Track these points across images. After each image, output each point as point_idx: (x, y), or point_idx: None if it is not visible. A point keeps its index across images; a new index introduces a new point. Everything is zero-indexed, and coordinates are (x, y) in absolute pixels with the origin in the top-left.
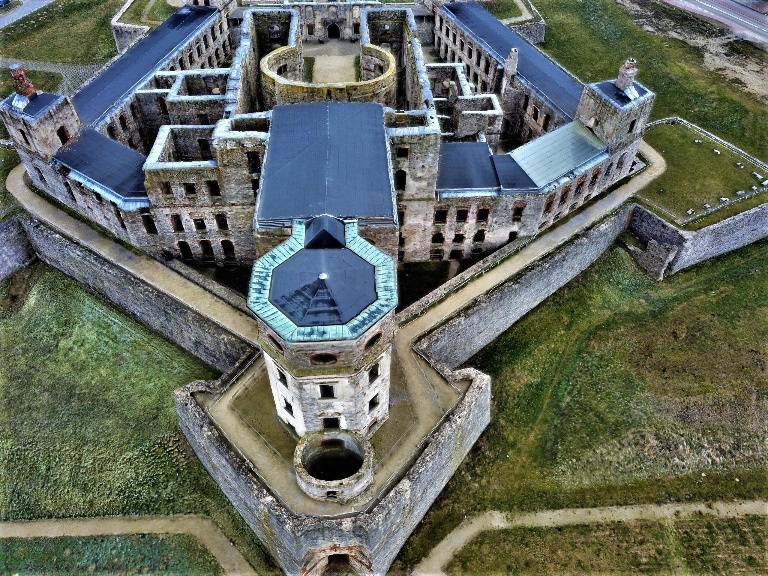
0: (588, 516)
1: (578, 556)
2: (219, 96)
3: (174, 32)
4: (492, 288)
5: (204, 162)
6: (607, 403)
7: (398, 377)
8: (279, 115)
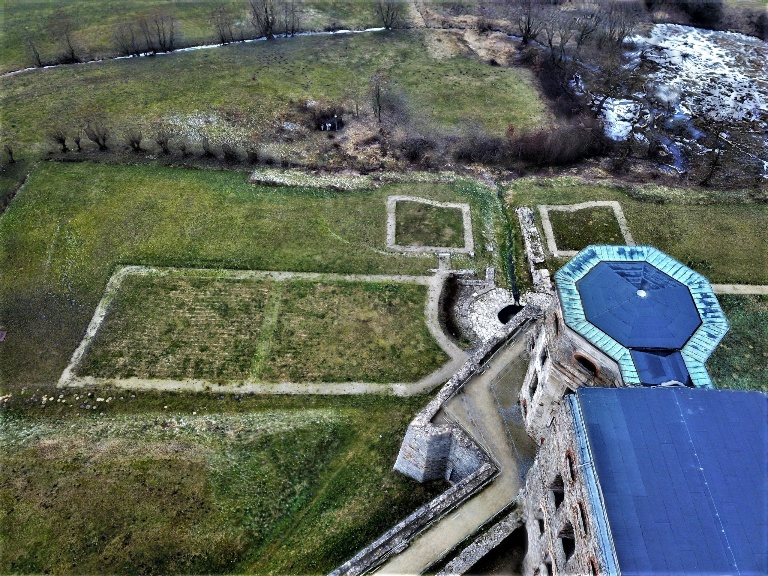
0: (320, 388)
1: (341, 360)
2: None
3: None
4: (380, 568)
5: None
6: (260, 469)
7: (513, 432)
8: None
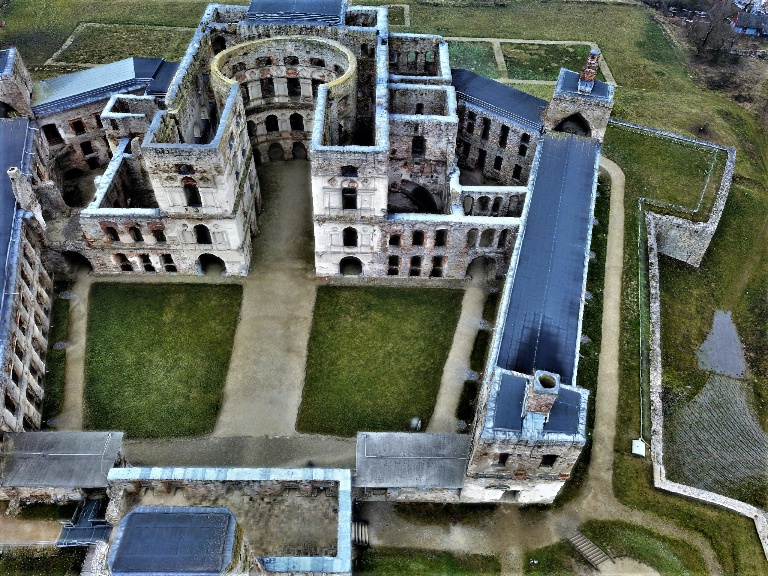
0: None
1: None
2: (402, 85)
3: (538, 306)
4: None
5: (398, 34)
6: None
7: None
8: (335, 8)
